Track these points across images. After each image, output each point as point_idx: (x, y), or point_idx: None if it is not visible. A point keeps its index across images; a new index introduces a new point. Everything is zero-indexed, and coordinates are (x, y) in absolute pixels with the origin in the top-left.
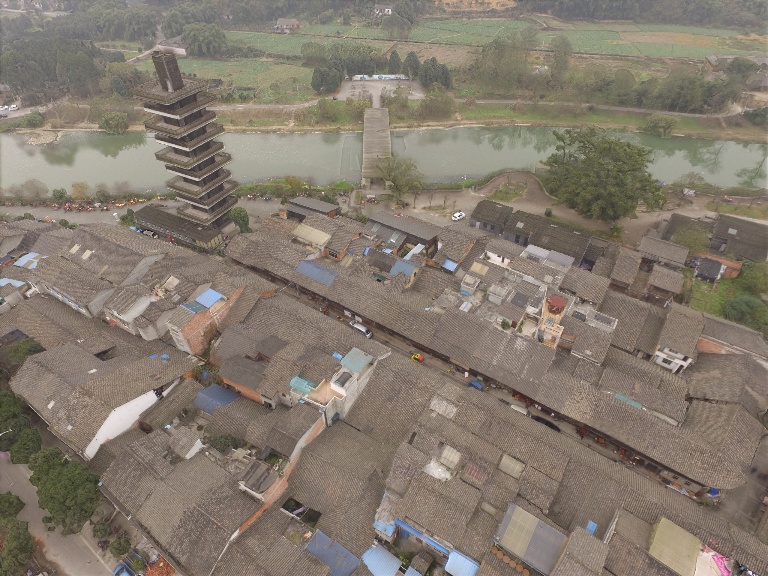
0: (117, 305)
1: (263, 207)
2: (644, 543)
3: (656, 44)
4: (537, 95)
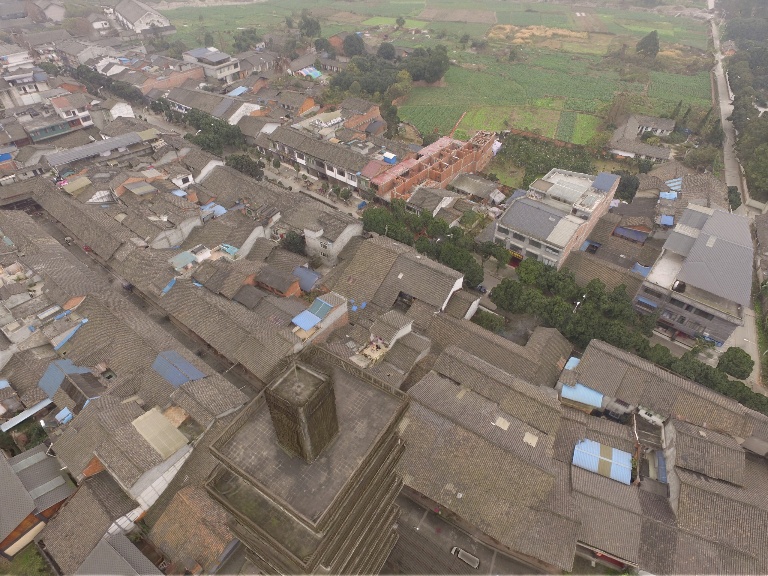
0: (403, 318)
1: None
2: (89, 188)
3: None
4: None
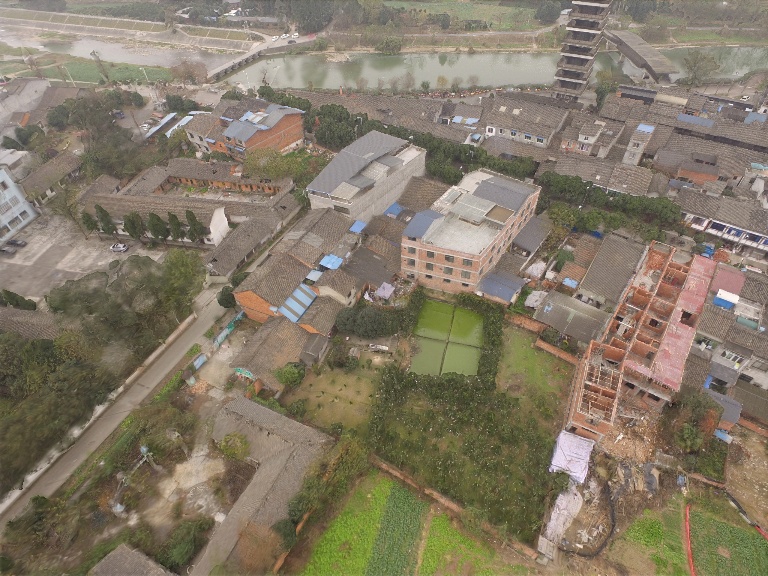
0: (586, 132)
1: (584, 95)
2: None
3: None
4: None
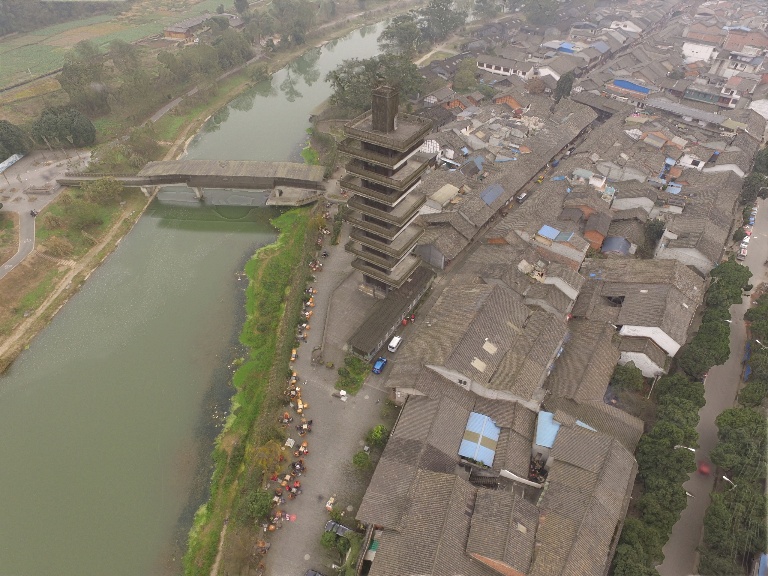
0: (577, 284)
1: (340, 258)
2: None
3: (94, 39)
4: (166, 97)
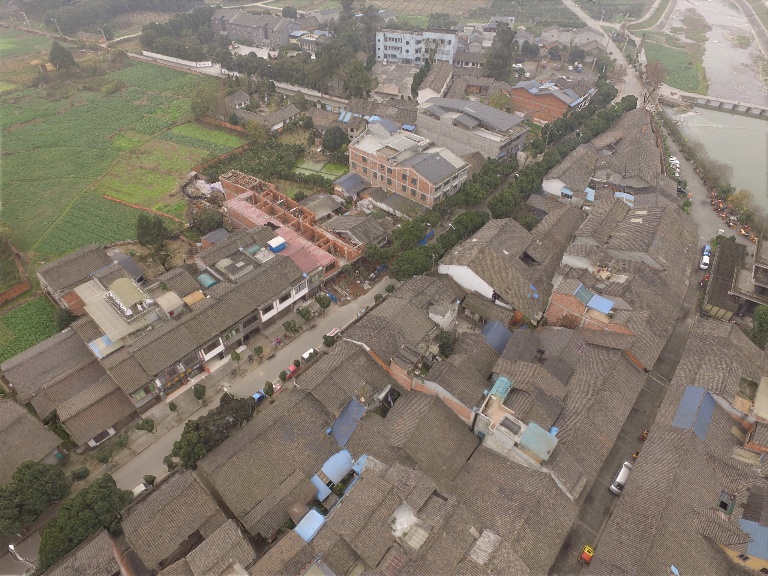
0: (573, 247)
1: None
2: None
3: None
4: None
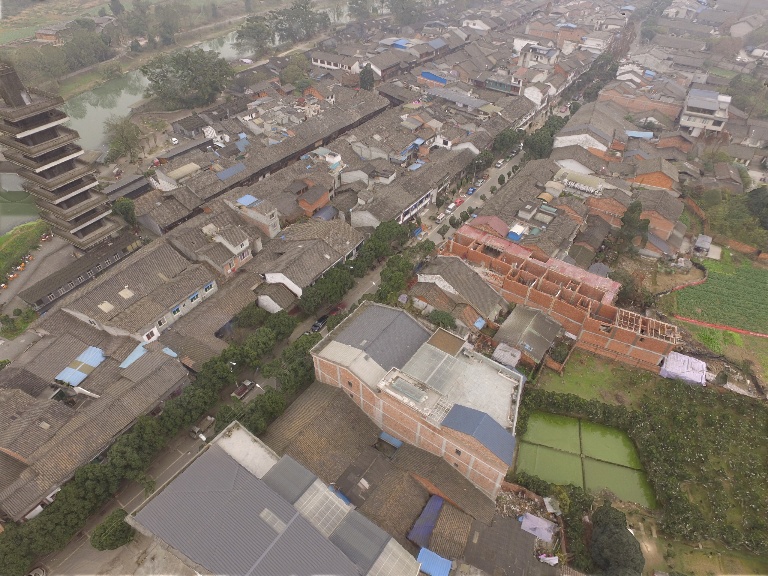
0: (236, 240)
1: None
2: None
3: None
4: None
